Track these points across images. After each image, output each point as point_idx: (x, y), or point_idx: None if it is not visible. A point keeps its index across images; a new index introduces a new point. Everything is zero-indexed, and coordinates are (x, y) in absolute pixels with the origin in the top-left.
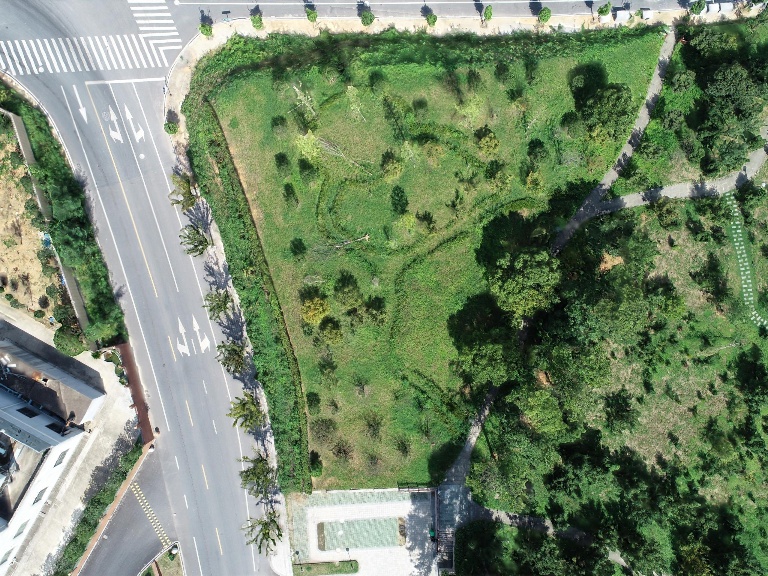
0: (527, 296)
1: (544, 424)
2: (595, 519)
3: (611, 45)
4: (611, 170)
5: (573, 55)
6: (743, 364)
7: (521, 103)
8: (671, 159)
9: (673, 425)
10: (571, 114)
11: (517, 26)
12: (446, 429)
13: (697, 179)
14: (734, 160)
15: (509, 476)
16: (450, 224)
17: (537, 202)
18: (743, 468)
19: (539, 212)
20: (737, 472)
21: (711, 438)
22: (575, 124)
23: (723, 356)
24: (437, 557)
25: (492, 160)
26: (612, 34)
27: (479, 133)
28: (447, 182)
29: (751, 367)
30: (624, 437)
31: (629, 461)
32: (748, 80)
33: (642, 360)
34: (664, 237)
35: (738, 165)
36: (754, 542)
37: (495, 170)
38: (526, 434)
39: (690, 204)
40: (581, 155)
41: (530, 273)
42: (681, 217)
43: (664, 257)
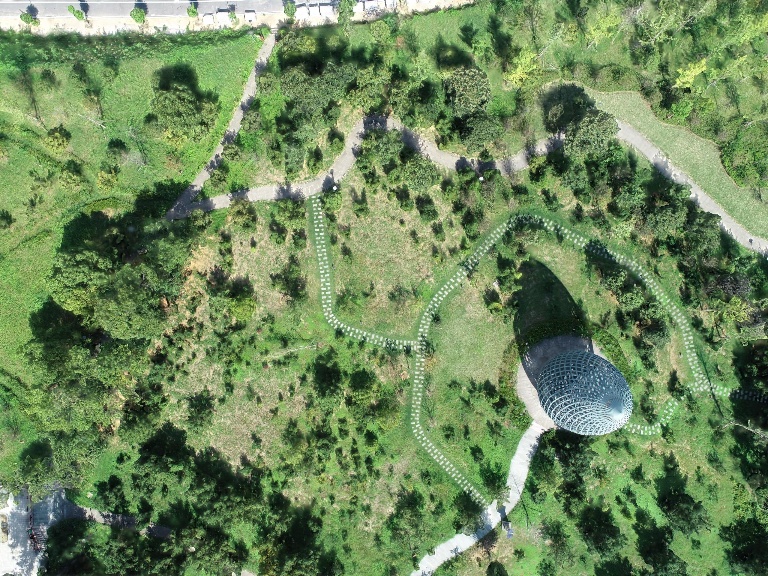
0: (71, 295)
1: (51, 423)
2: (184, 519)
3: (202, 47)
4: (203, 171)
5: (157, 56)
6: (319, 367)
7: (84, 103)
8: (257, 161)
9: (256, 426)
10: (156, 115)
11: (122, 26)
12: (34, 427)
13: (283, 181)
14: (296, 163)
15: (30, 474)
16: (30, 223)
17: (120, 202)
18: (322, 470)
19: (124, 212)
20: (316, 474)
21: (291, 440)
22: (145, 125)
23: (303, 358)
24: (39, 554)
25: (69, 160)
26: (211, 36)
27: (53, 133)
28: (22, 181)
29: (324, 370)
30: (209, 438)
31: (214, 462)
32: (303, 83)
33: (222, 361)
34: (247, 239)
35: (315, 168)
36: (337, 544)
37: (72, 170)
38: (53, 433)
39: (274, 206)
40: (170, 156)
41: (64, 272)
42: (265, 219)
43: (246, 259)
